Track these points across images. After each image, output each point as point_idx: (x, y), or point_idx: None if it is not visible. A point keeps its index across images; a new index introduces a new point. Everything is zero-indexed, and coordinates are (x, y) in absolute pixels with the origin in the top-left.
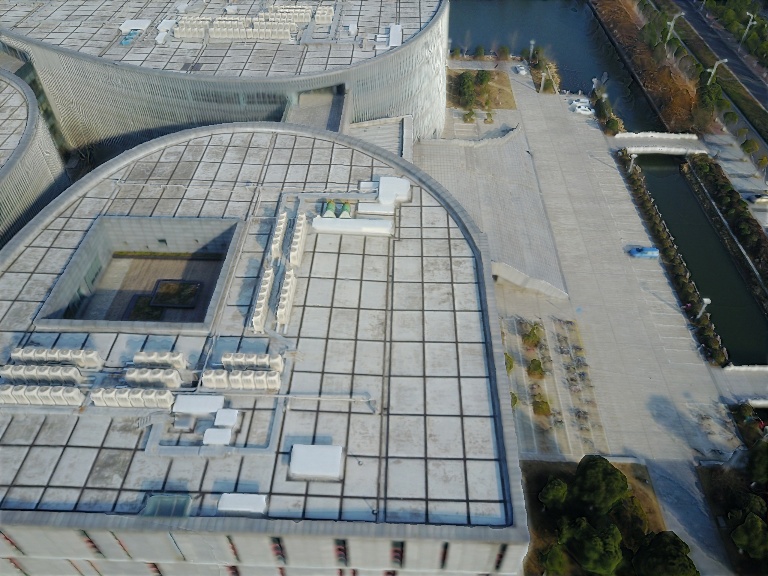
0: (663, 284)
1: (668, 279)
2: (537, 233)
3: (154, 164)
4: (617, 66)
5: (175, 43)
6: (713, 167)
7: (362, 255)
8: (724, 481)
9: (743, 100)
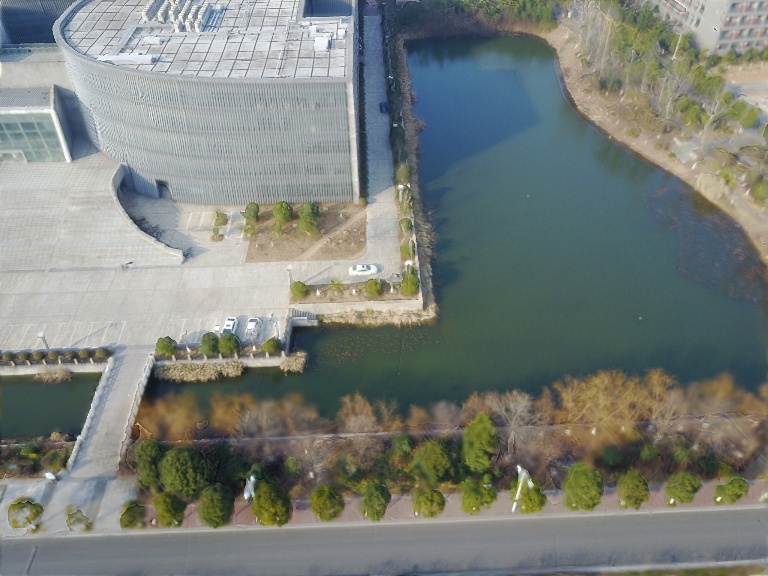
0: None
1: None
2: None
3: None
4: None
5: None
6: (24, 461)
7: None
8: None
9: None
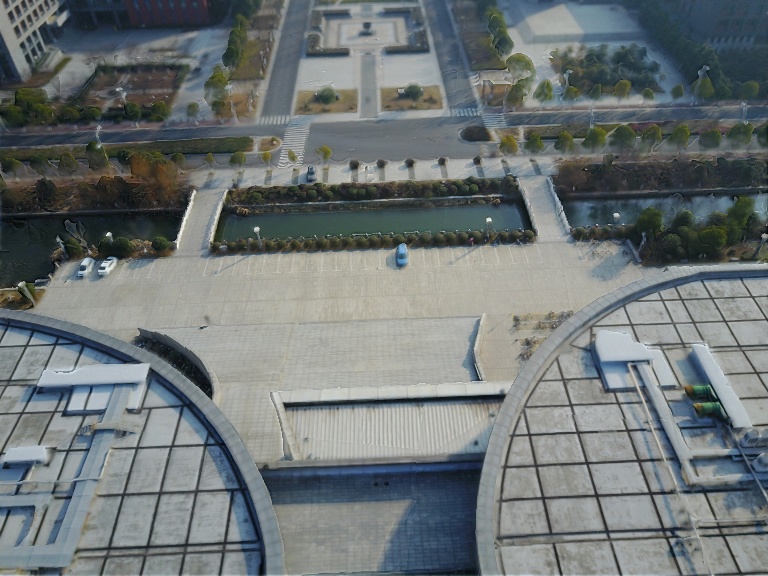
0: (442, 251)
1: (434, 247)
2: (384, 330)
3: None
4: None
5: None
6: (256, 190)
7: (760, 374)
8: (660, 250)
9: (132, 148)
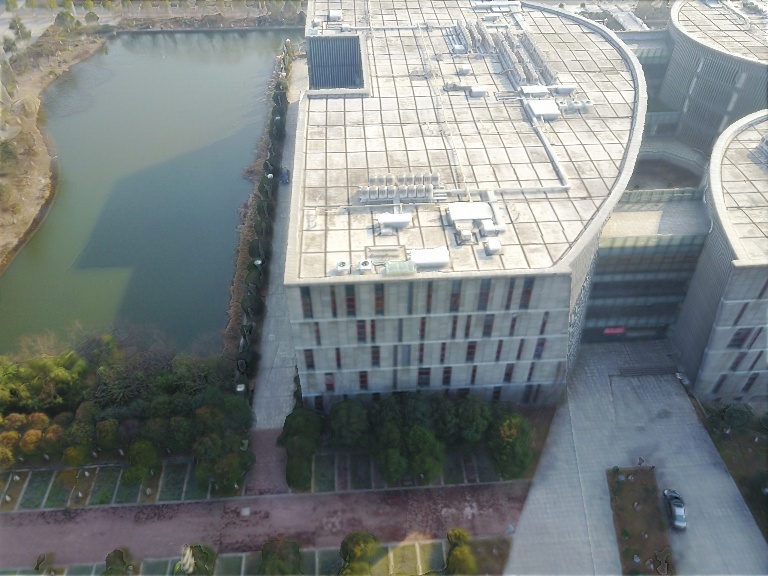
0: None
1: None
2: None
3: (764, 60)
4: (259, 43)
5: (568, 84)
6: None
7: None
8: None
9: None
